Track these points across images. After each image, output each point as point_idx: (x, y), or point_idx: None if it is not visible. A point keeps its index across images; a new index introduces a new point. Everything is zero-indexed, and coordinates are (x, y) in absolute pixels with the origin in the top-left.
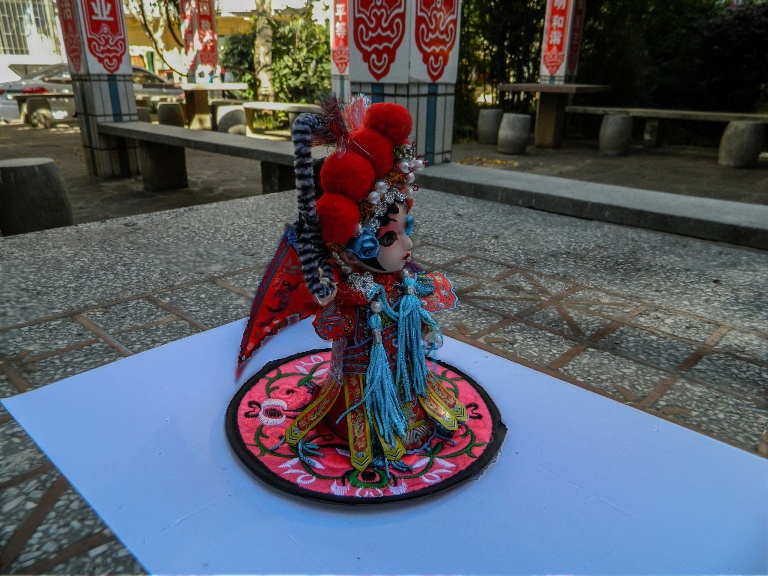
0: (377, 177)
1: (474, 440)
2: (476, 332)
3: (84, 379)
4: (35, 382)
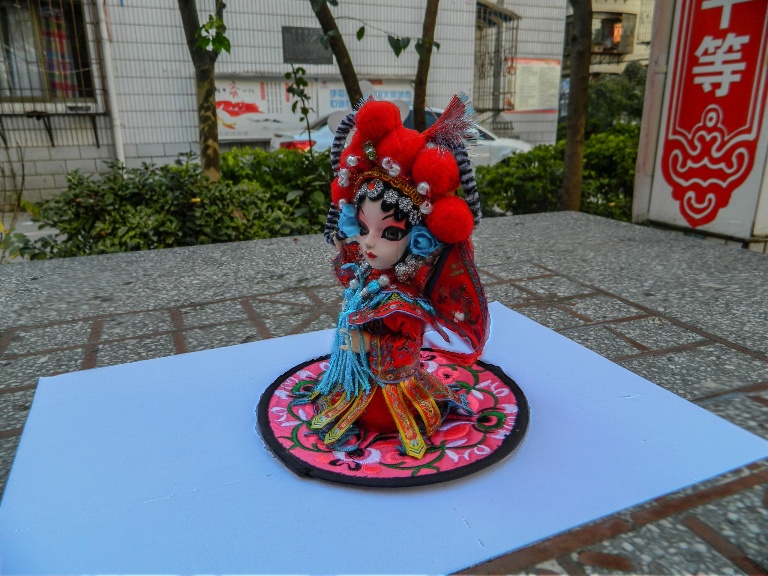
0: (362, 167)
1: (303, 447)
2: (589, 573)
3: (519, 319)
4: (520, 308)
